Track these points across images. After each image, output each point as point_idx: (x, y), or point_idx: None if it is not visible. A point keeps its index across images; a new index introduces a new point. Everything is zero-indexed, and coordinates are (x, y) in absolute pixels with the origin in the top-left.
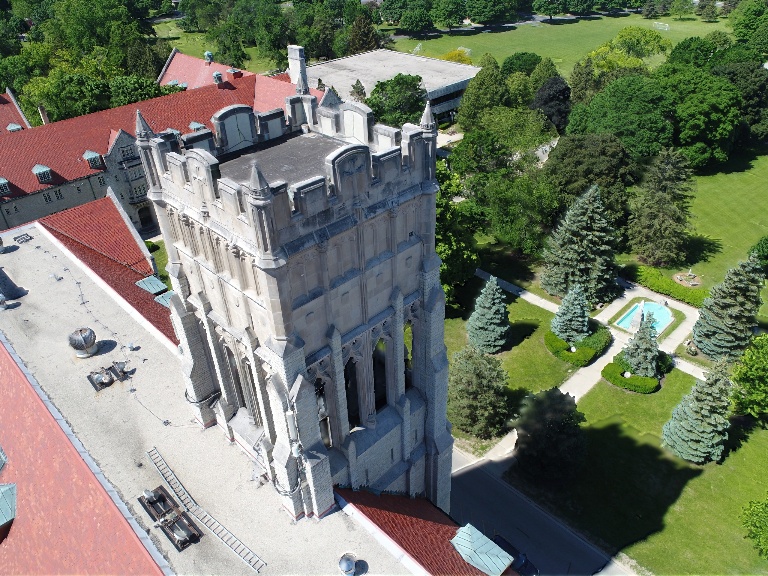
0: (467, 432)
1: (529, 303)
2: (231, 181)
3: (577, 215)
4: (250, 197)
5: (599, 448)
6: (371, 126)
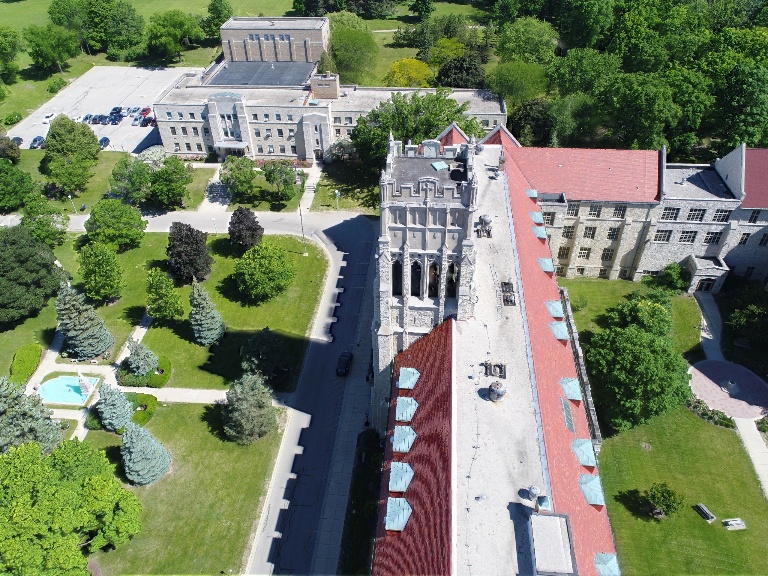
0: None
1: None
2: None
3: None
4: None
5: (238, 365)
6: None
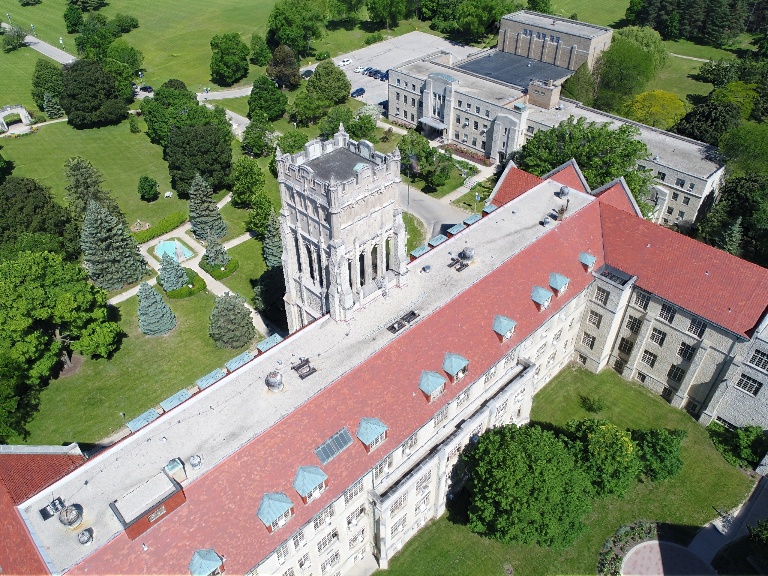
0: (247, 343)
1: (124, 301)
2: (377, 166)
3: (96, 227)
4: (398, 158)
5: None
6: (322, 145)
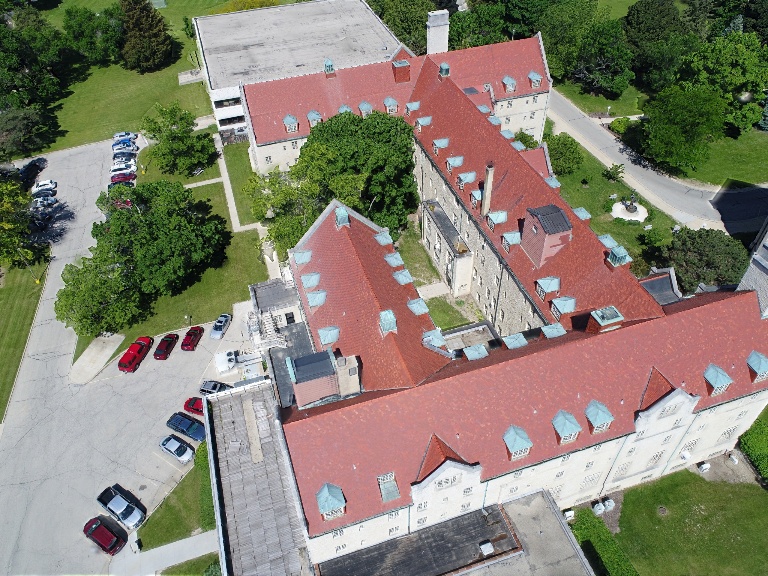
0: None
1: None
2: None
3: None
4: None
5: None
6: None
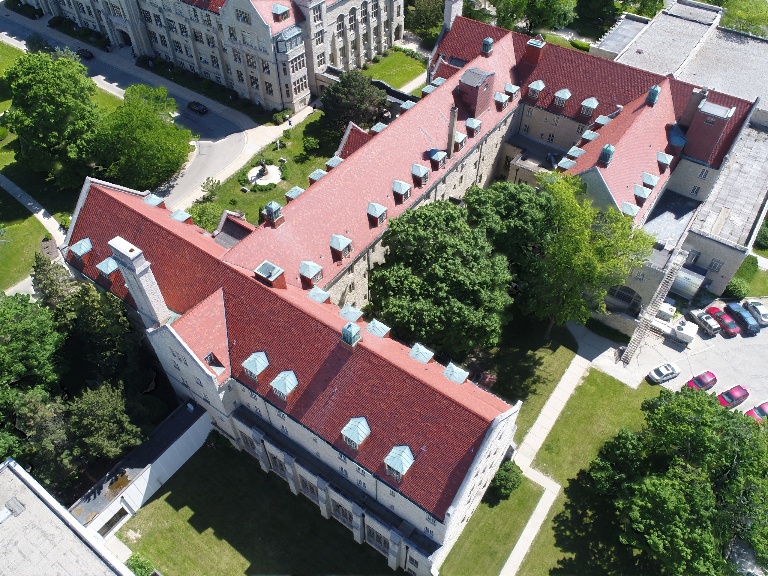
0: None
1: None
2: None
3: None
4: None
5: None
6: None
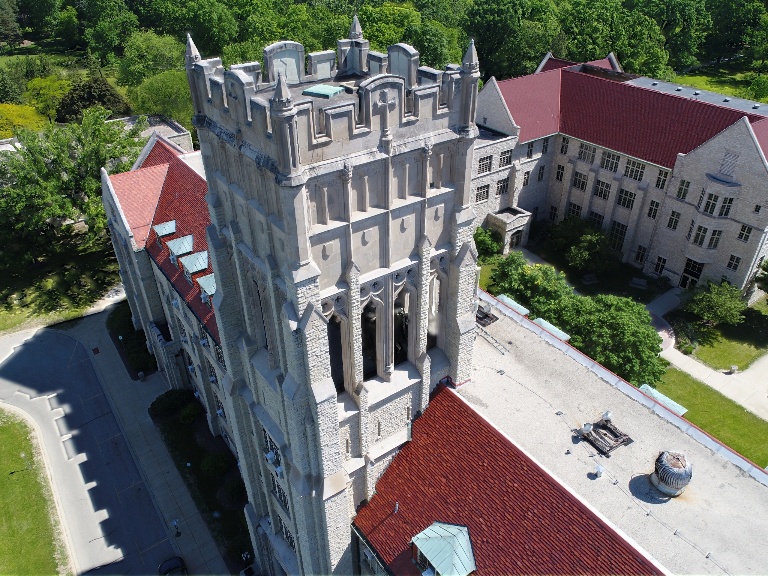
0: None
1: None
2: (379, 54)
3: None
4: None
5: None
6: None
